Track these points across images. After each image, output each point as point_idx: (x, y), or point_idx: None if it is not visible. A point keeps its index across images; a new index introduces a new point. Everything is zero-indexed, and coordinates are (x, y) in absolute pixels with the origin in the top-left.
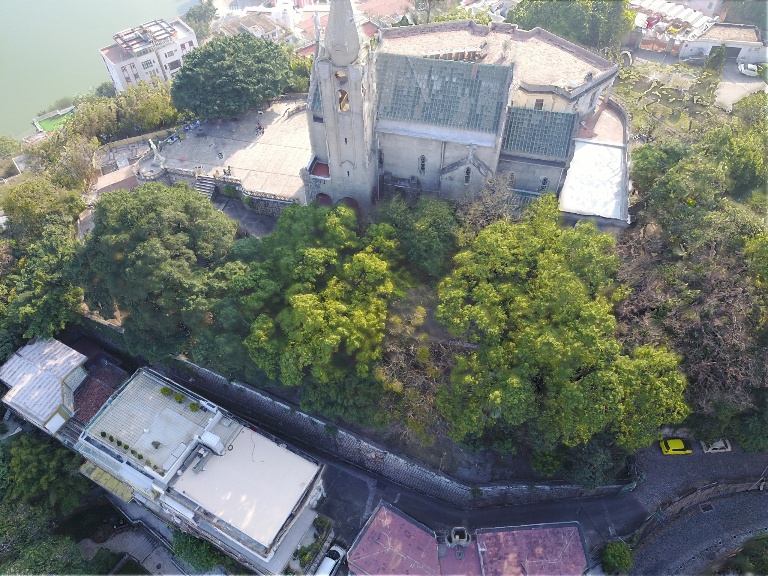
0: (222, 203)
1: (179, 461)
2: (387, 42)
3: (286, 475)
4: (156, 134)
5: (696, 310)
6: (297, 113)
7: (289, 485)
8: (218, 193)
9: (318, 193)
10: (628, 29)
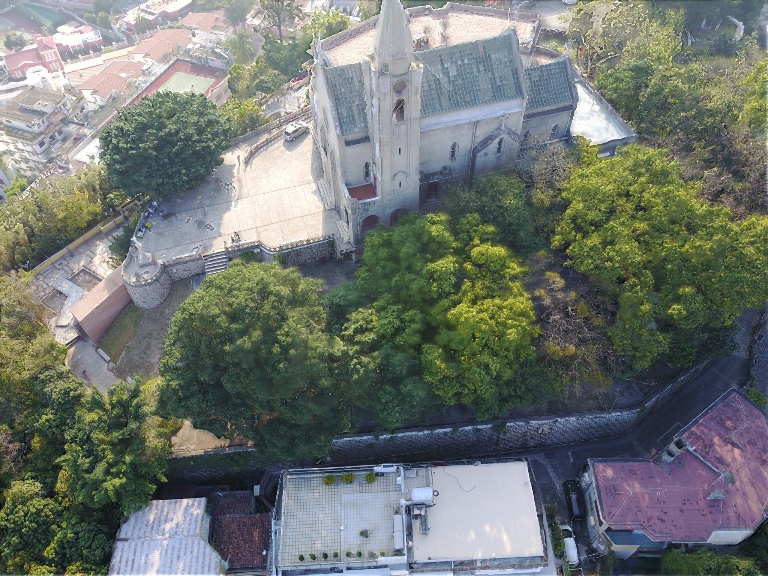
0: None
1: (405, 533)
2: (327, 55)
3: (505, 485)
4: (80, 240)
5: (738, 180)
6: (252, 157)
7: (516, 492)
8: None
9: (366, 217)
10: None
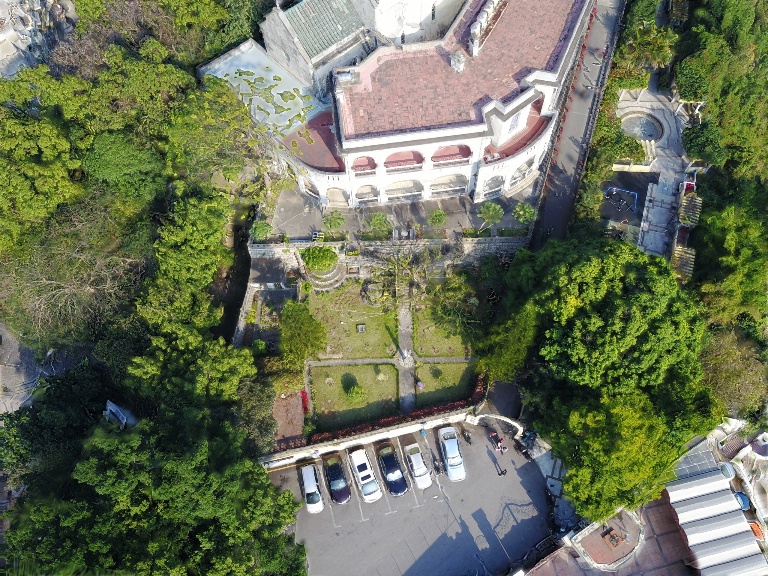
0: None
1: None
2: None
3: None
4: None
5: None
6: None
7: None
8: None
9: None
10: None
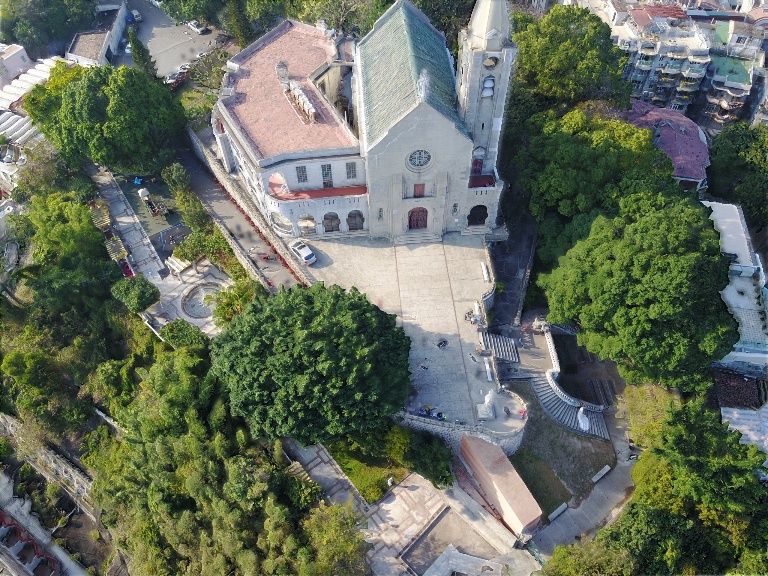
0: (499, 329)
1: None
2: None
3: None
4: None
5: None
6: None
7: None
8: None
9: None
10: None
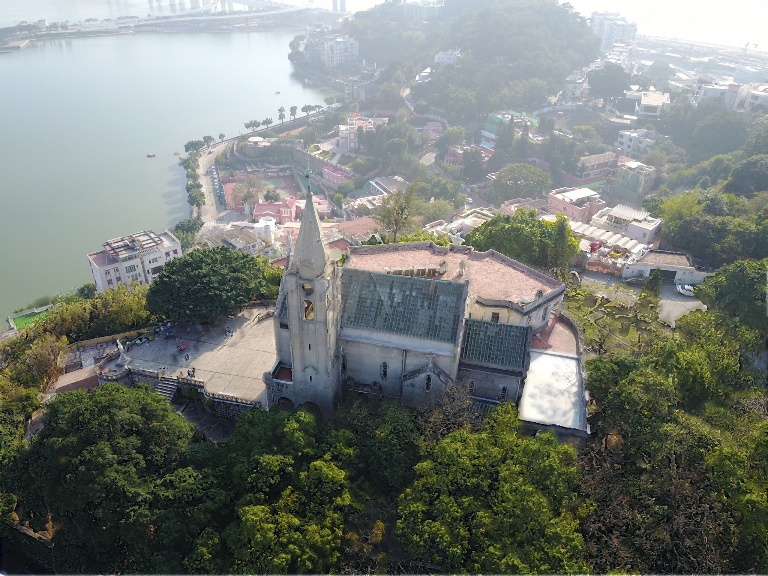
0: (182, 405)
1: None
2: (355, 258)
3: None
4: (126, 334)
5: (665, 528)
6: (267, 318)
7: None
8: (179, 394)
9: (280, 397)
10: (574, 253)
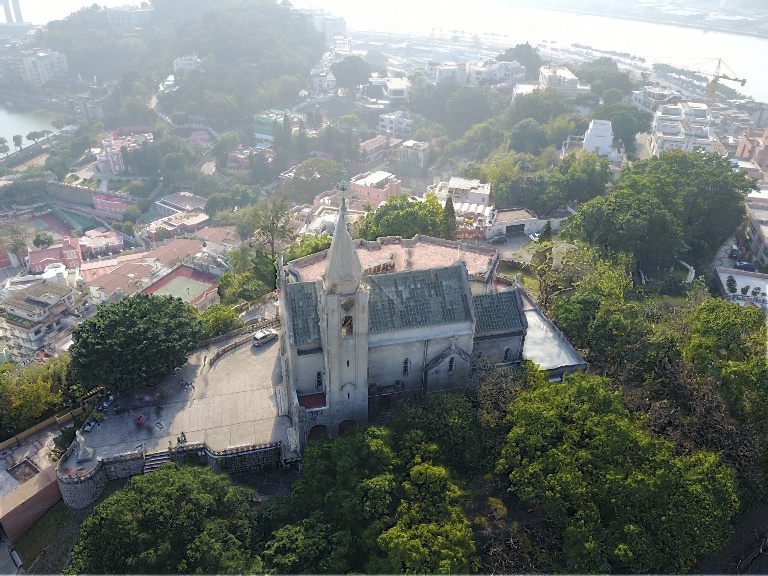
0: None
1: None
2: (300, 272)
3: None
4: (32, 430)
5: (686, 414)
6: (218, 359)
7: None
8: None
9: (313, 426)
10: None
